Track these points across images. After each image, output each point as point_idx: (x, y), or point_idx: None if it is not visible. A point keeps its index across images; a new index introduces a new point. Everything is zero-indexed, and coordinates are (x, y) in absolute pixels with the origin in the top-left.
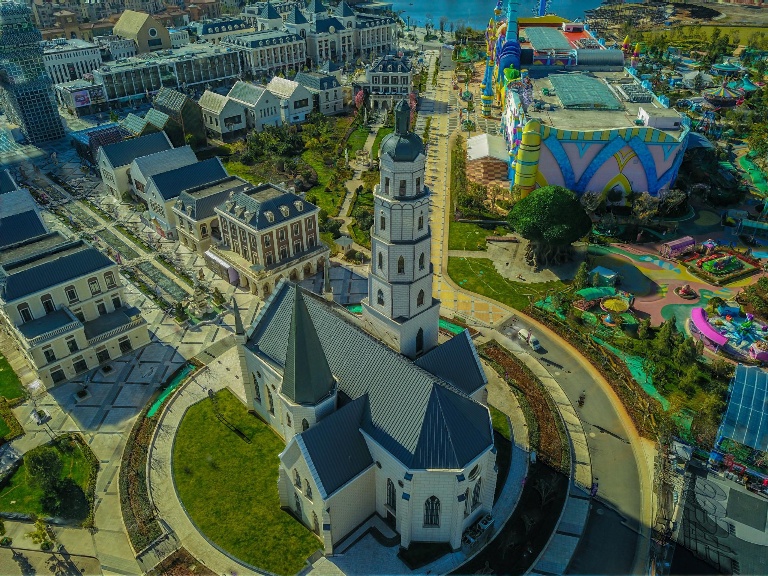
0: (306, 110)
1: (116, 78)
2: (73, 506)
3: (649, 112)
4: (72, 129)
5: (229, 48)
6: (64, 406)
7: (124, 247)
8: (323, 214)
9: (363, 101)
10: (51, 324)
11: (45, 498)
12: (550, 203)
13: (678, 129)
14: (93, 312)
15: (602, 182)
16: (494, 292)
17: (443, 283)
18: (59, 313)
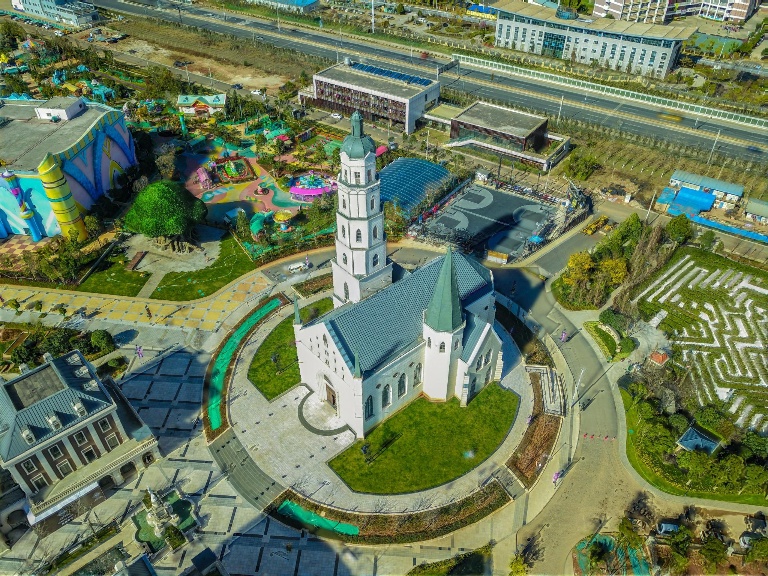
0: None
1: None
2: (469, 572)
3: (51, 108)
4: None
5: None
6: None
7: None
8: None
9: None
10: None
11: None
12: (176, 194)
13: (87, 109)
14: None
15: (106, 176)
16: (226, 277)
17: (197, 306)
18: None
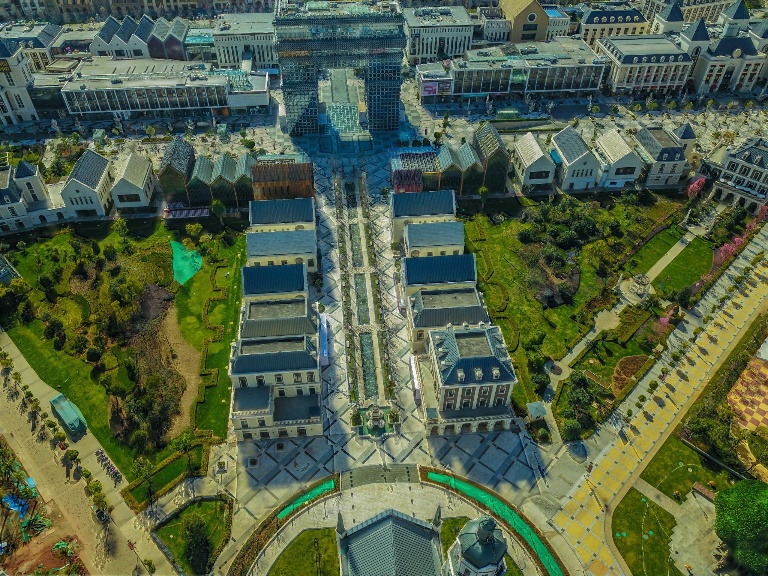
0: (629, 178)
1: (467, 75)
2: (197, 568)
3: None
4: (408, 120)
5: (596, 60)
6: (239, 465)
7: (365, 305)
8: (538, 362)
9: (700, 191)
10: (255, 399)
11: (187, 547)
12: (767, 526)
13: None
14: (292, 392)
15: None
16: (643, 571)
17: (599, 522)
18: (266, 389)
